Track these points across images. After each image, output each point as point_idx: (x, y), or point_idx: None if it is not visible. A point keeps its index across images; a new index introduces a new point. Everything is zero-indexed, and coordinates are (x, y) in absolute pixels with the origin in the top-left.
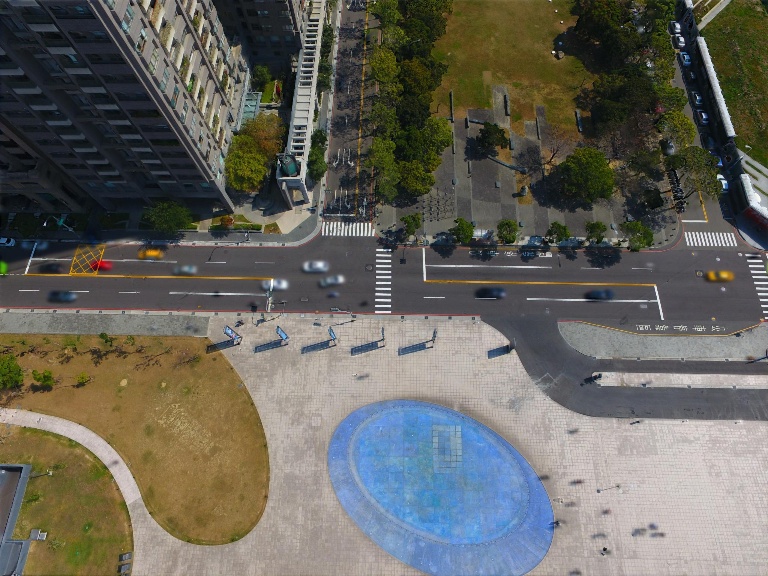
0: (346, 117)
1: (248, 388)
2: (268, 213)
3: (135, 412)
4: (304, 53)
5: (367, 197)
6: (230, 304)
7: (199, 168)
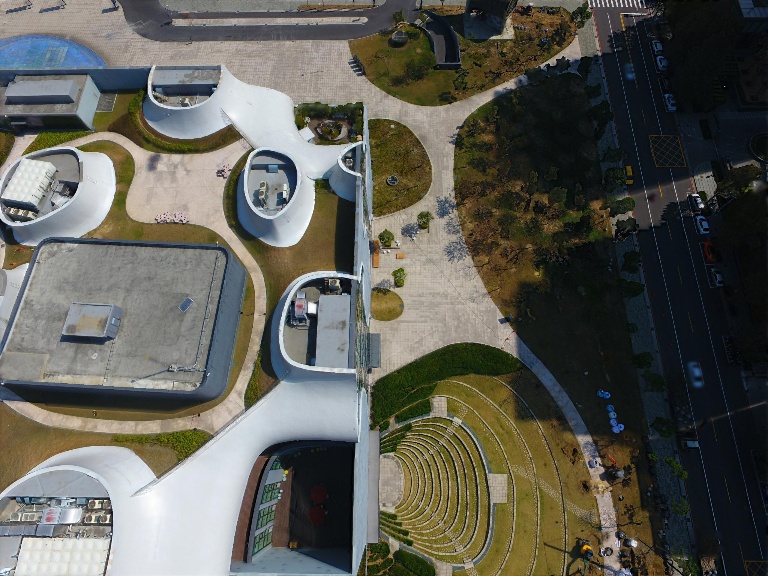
0: None
1: None
2: None
3: None
4: None
5: None
6: None
7: None
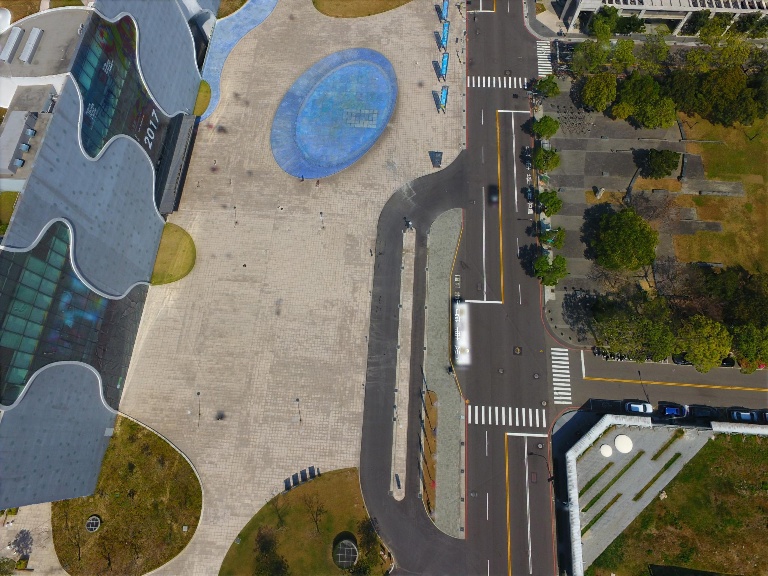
0: (669, 55)
1: (409, 3)
2: (555, 4)
3: None
4: (735, 1)
5: None
6: None
7: None
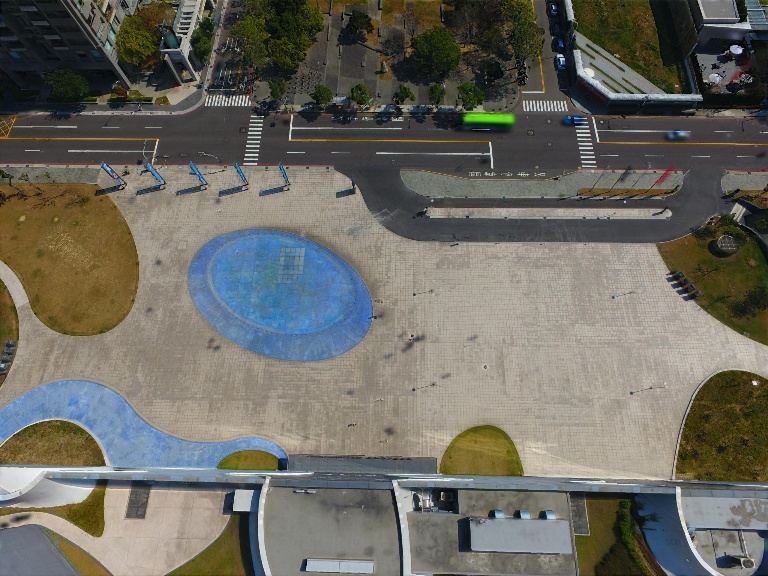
0: (238, 13)
1: (127, 221)
2: (160, 88)
3: (30, 240)
4: None
5: (248, 75)
6: (119, 159)
7: (83, 31)
